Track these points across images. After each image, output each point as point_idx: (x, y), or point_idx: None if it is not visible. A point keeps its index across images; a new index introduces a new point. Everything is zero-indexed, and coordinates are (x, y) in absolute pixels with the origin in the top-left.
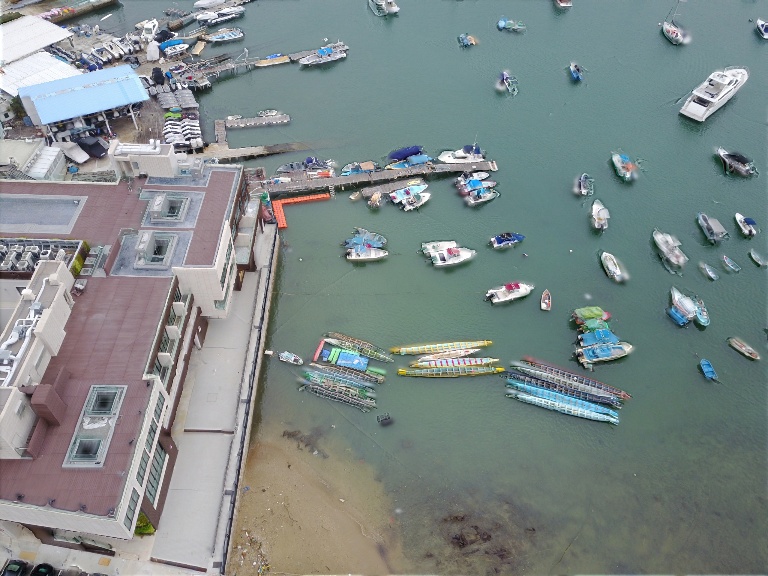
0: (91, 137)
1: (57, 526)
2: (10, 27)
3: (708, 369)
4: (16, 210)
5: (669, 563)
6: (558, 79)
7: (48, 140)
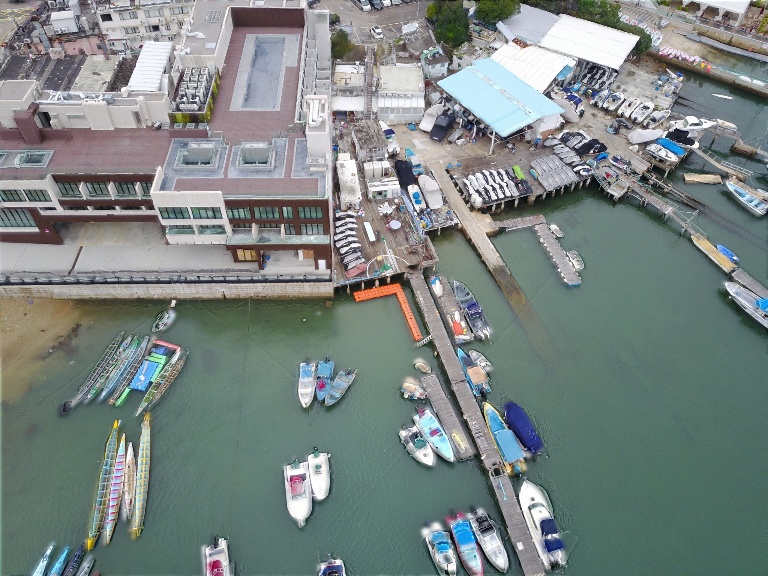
0: (446, 121)
1: None
2: (606, 32)
3: None
4: (272, 83)
5: None
6: None
7: (441, 100)
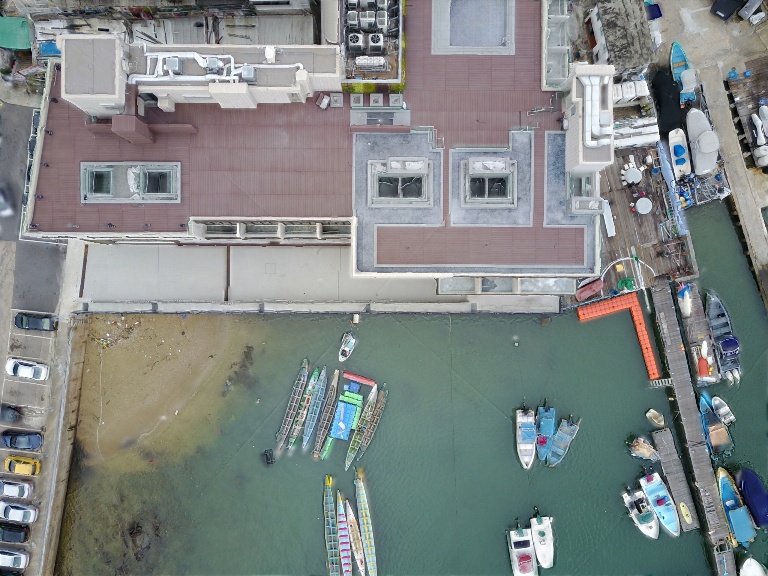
0: None
1: None
2: None
3: None
4: None
5: None
6: None
7: None
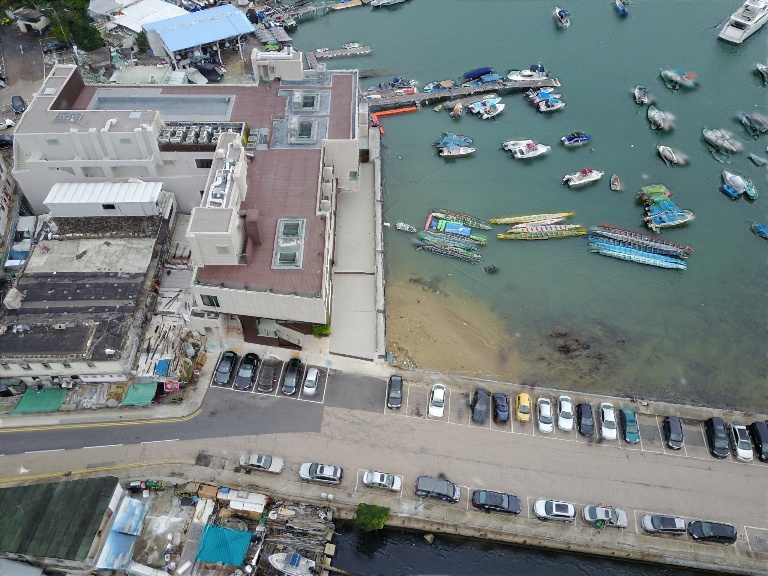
0: (209, 63)
1: (269, 314)
2: None
3: (759, 230)
4: (178, 107)
5: (736, 363)
6: (605, 13)
7: (172, 67)
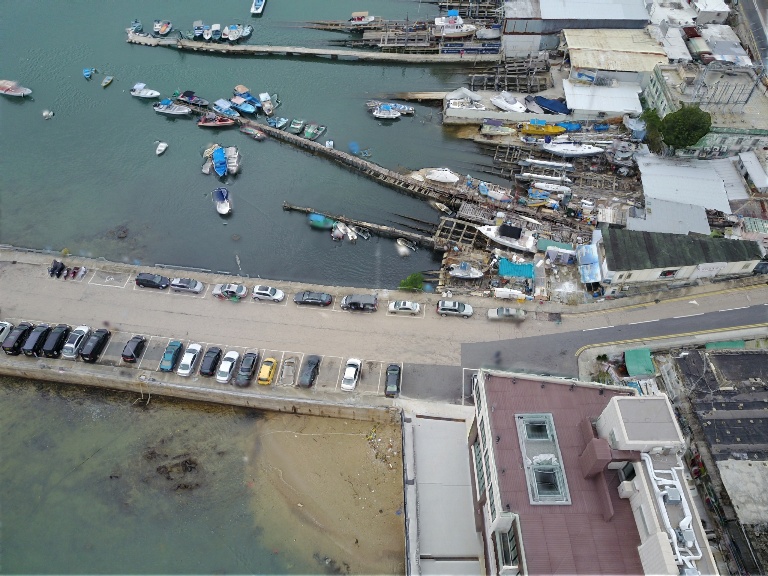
0: None
1: None
2: None
3: None
4: None
5: None
6: None
7: None
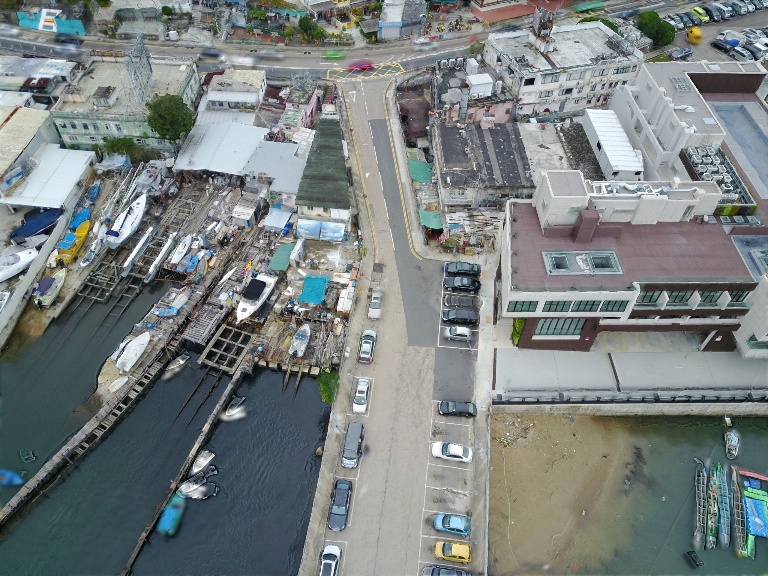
0: None
1: (502, 270)
2: None
3: None
4: (767, 161)
5: None
6: None
7: None
